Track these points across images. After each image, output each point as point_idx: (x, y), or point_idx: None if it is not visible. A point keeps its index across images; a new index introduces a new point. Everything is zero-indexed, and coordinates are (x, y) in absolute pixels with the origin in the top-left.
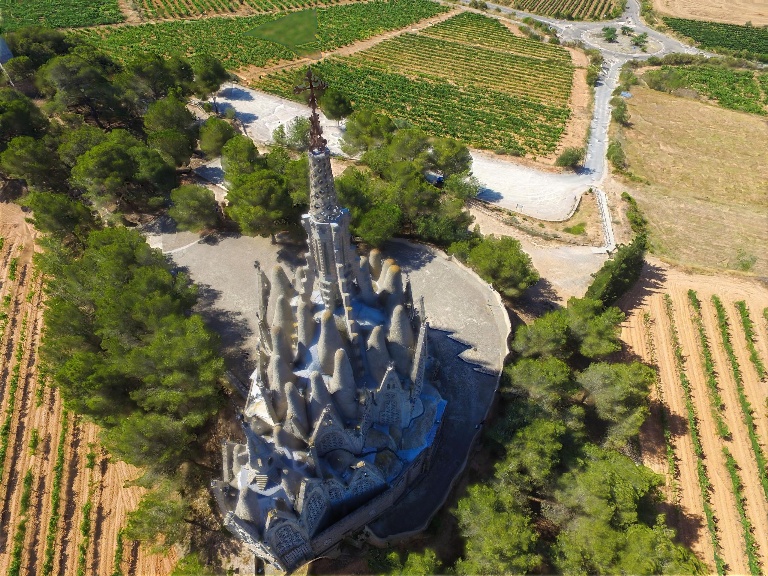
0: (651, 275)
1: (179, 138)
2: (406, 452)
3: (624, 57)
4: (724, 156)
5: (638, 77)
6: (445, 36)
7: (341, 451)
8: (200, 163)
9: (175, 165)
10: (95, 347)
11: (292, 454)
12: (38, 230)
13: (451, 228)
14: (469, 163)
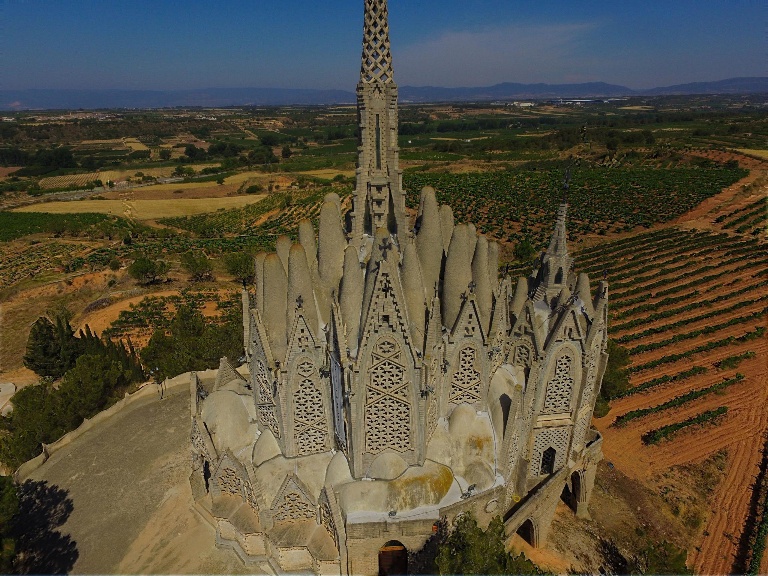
0: None
1: None
2: None
3: None
4: None
5: None
6: None
7: None
8: None
9: None
10: None
11: None
12: None
13: None
14: None
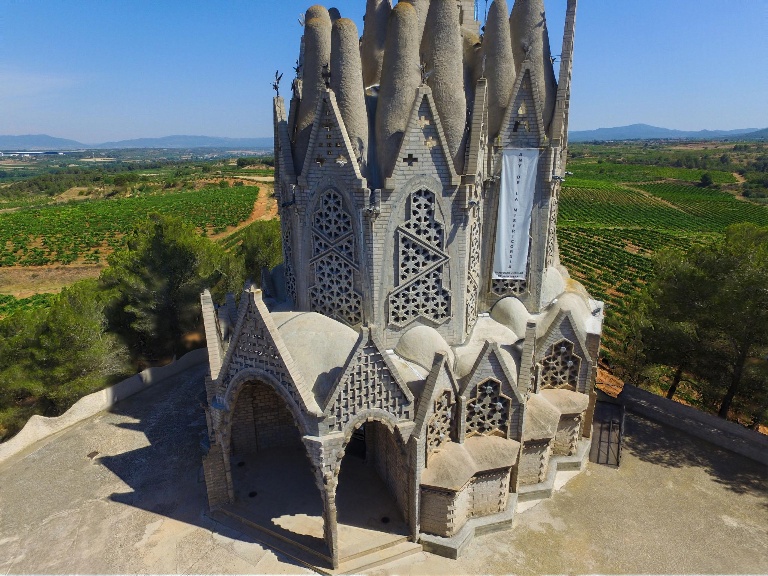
0: None
1: None
2: None
3: None
4: None
5: None
6: None
7: None
8: None
9: None
10: None
11: None
12: None
13: None
14: None
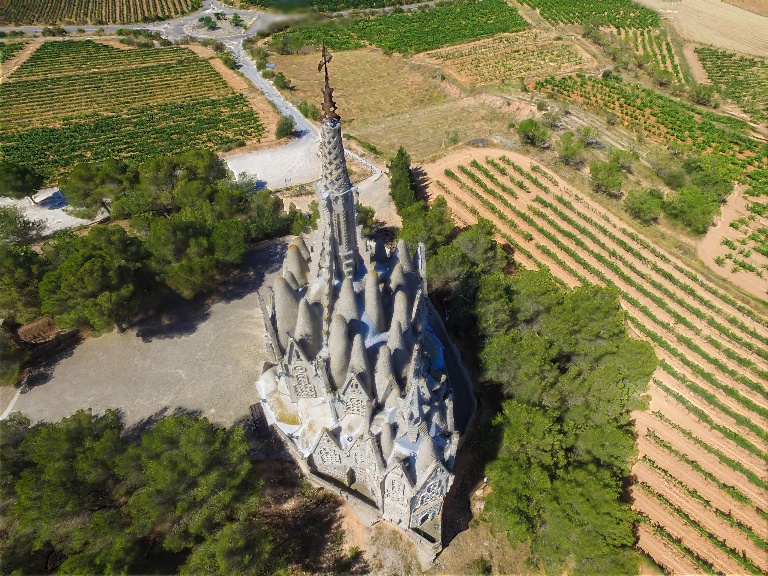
0: (417, 175)
1: None
2: (435, 364)
3: (236, 38)
4: (370, 84)
5: (266, 49)
6: (46, 73)
7: None
8: None
9: None
10: (32, 574)
11: None
12: None
13: None
14: (225, 164)
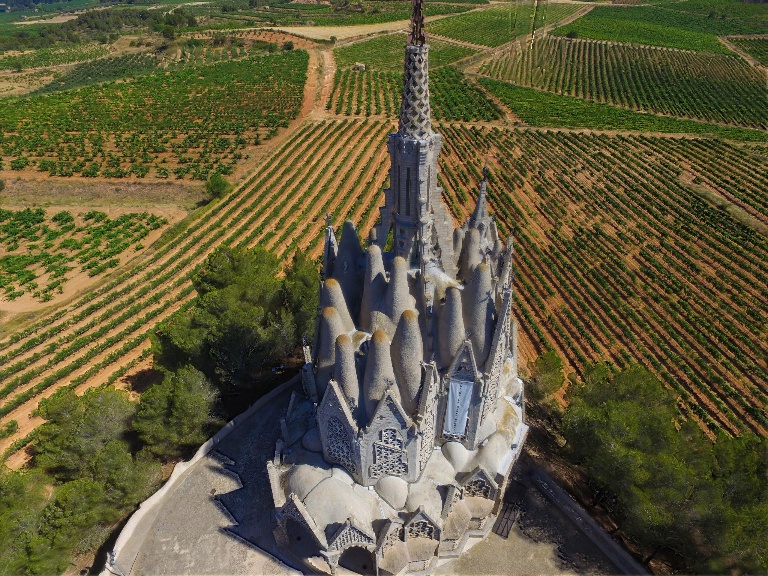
0: None
1: None
2: None
3: None
4: None
5: None
6: None
7: None
8: None
9: None
10: None
11: None
12: None
13: None
14: None
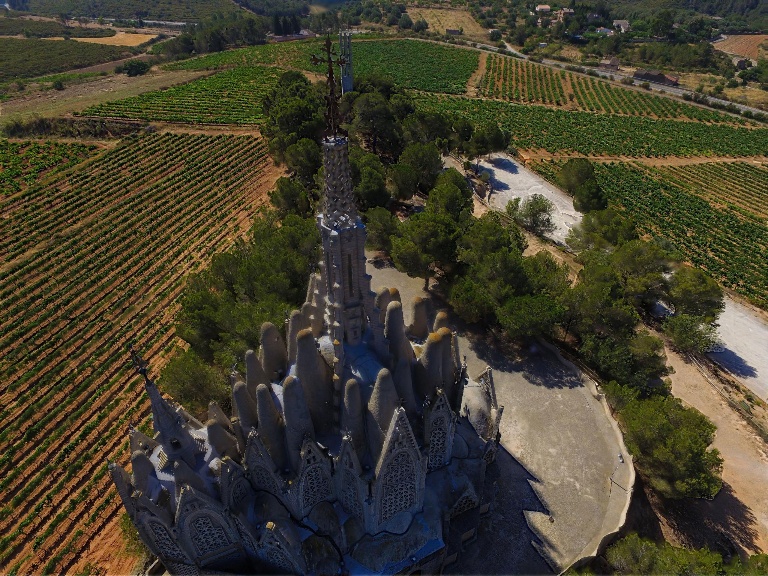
0: None
1: (411, 174)
2: (355, 563)
3: None
4: None
5: None
6: None
7: (274, 499)
8: (423, 203)
9: (398, 196)
10: (234, 299)
11: (212, 458)
12: (271, 203)
13: (629, 366)
14: (716, 310)
